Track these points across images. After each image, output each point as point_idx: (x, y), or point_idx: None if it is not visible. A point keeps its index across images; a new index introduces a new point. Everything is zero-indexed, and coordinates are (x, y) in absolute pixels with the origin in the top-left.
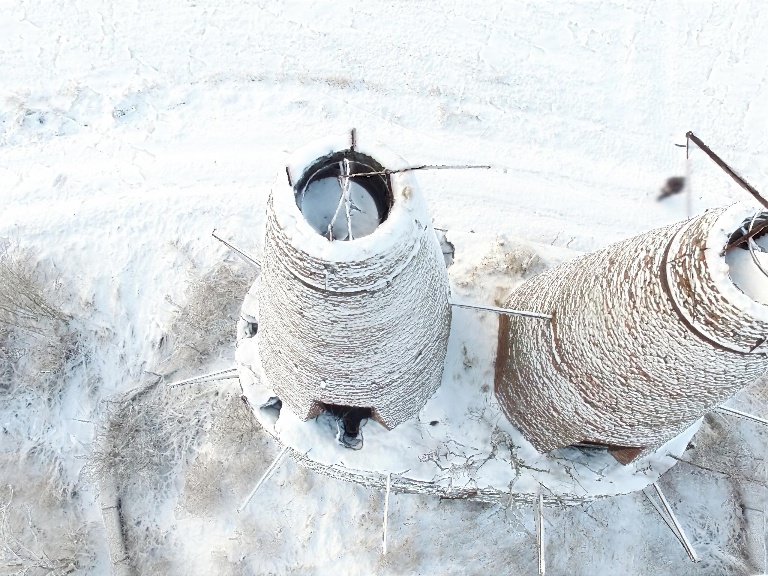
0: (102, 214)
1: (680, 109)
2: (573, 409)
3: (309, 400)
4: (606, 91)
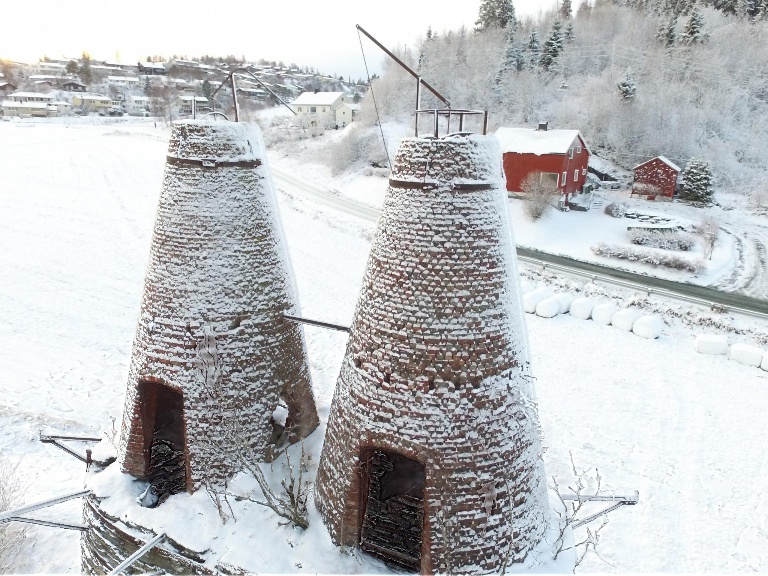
0: None
1: (705, 566)
2: (350, 390)
3: (136, 387)
4: (619, 533)
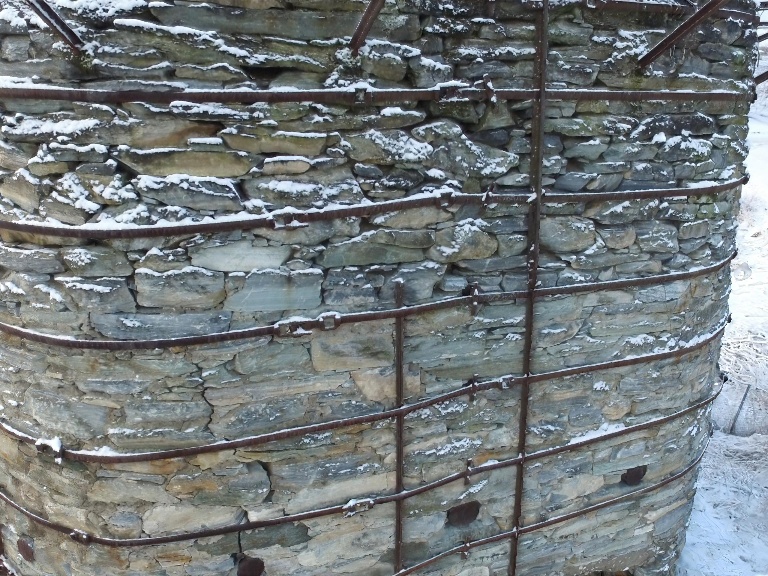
0: None
1: None
2: None
3: None
4: None
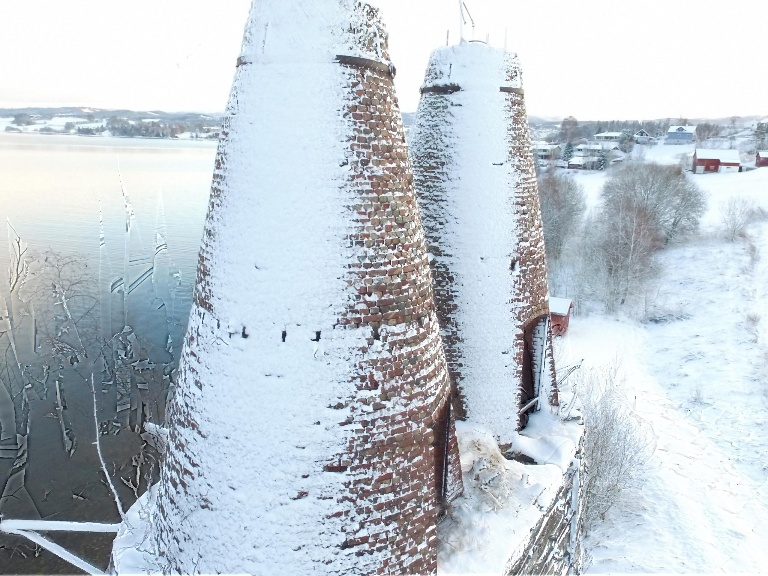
0: (699, 553)
1: None
2: None
3: None
4: None
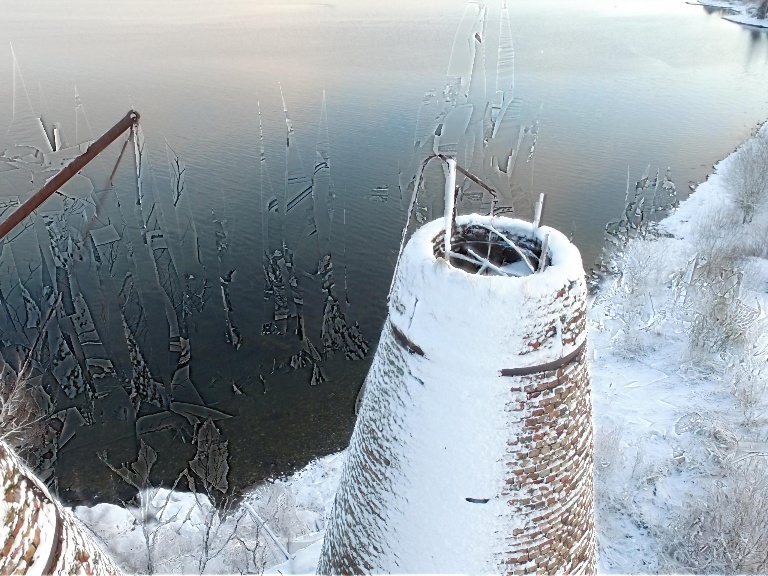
0: None
1: None
2: None
3: None
4: None
